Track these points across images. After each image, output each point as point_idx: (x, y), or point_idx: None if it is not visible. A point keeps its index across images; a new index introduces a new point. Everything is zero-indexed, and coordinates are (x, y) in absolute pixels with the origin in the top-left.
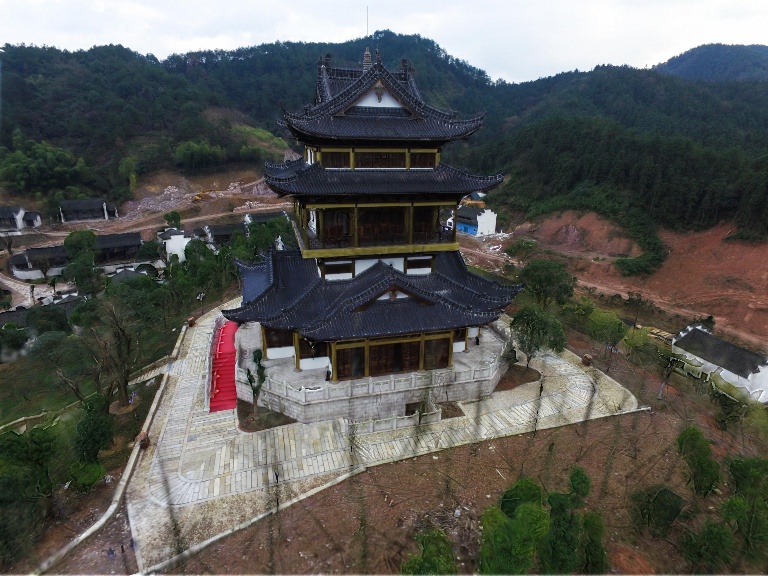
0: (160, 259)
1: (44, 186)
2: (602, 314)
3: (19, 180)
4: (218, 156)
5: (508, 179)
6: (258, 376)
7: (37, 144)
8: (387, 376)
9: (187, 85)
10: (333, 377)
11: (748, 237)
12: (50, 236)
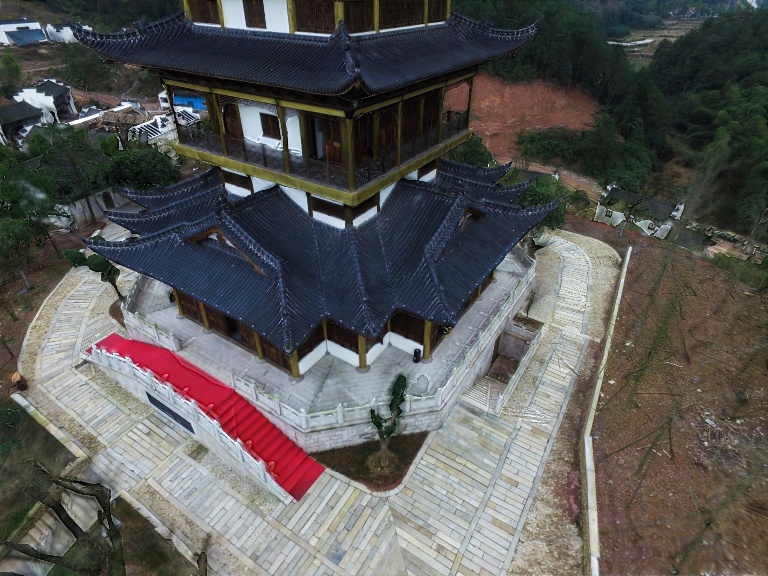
0: None
1: None
2: None
3: None
4: None
5: None
6: (394, 411)
7: None
8: (461, 321)
9: None
10: (426, 354)
11: None
12: None
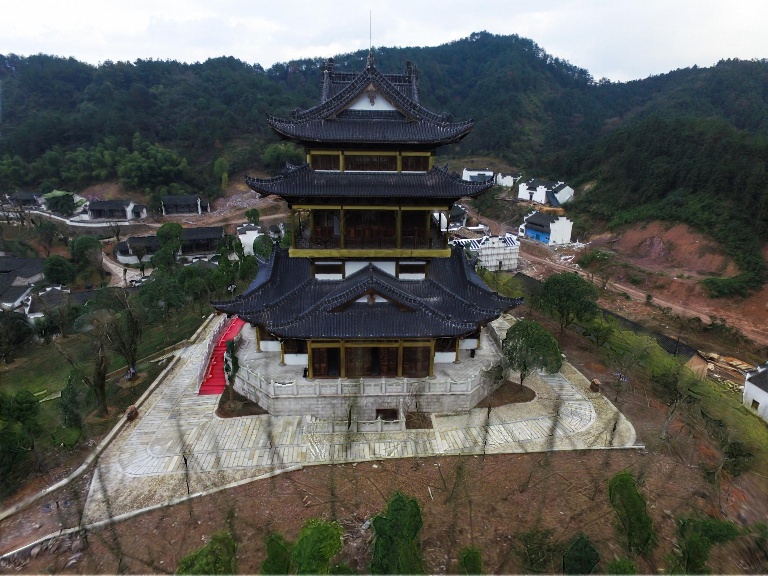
0: (235, 252)
1: (153, 183)
2: (631, 337)
3: (133, 177)
4: (302, 158)
5: (593, 185)
6: (232, 366)
7: (151, 146)
8: (363, 379)
9: (283, 91)
10: (309, 374)
11: None
12: (151, 227)
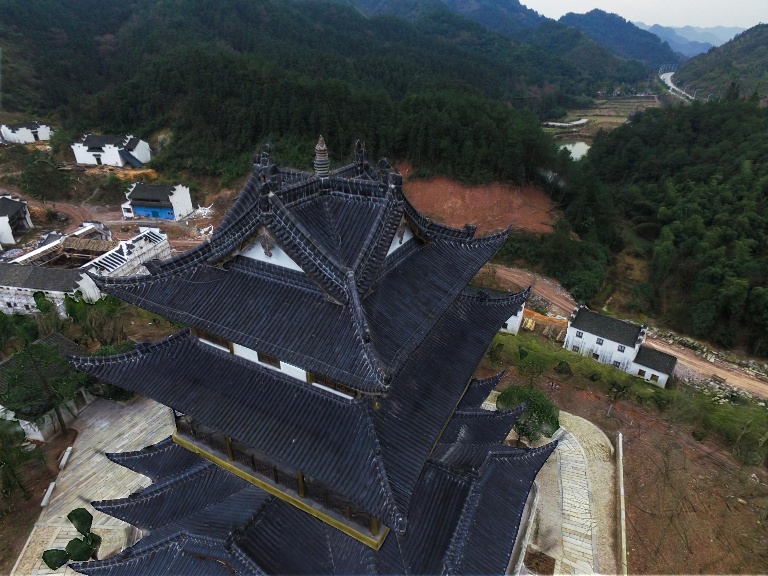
0: None
1: None
2: None
3: None
4: None
5: (168, 134)
6: None
7: None
8: None
9: None
10: None
11: (424, 175)
12: None
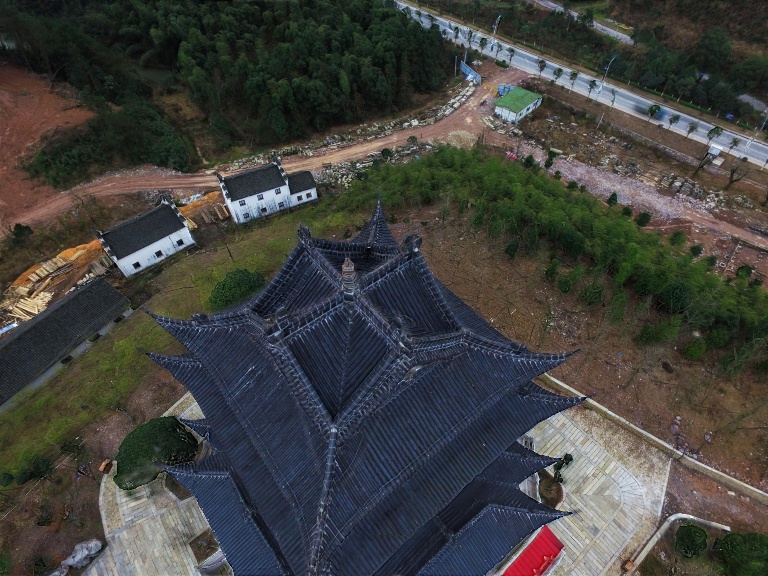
0: None
1: None
2: (254, 268)
3: None
4: None
5: None
6: None
7: None
8: None
9: None
10: None
11: None
12: None
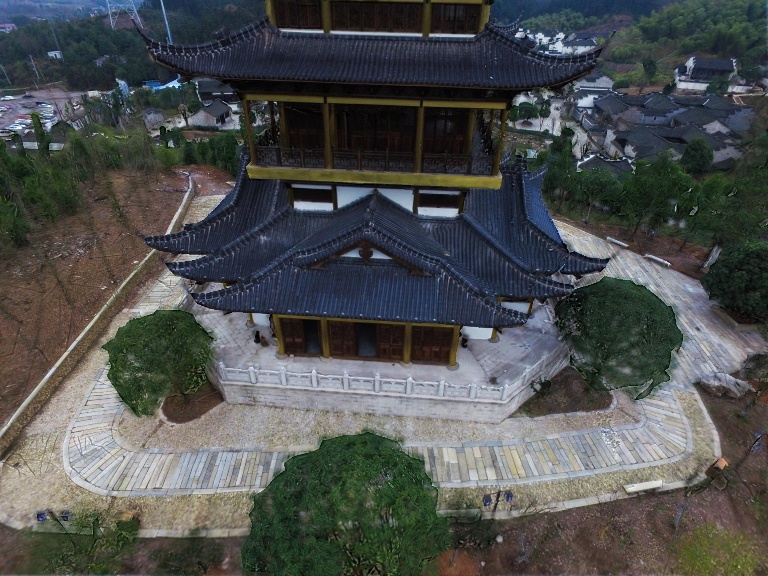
0: None
1: None
2: None
3: None
4: None
5: None
6: None
7: None
8: None
9: None
10: None
11: None
12: None
